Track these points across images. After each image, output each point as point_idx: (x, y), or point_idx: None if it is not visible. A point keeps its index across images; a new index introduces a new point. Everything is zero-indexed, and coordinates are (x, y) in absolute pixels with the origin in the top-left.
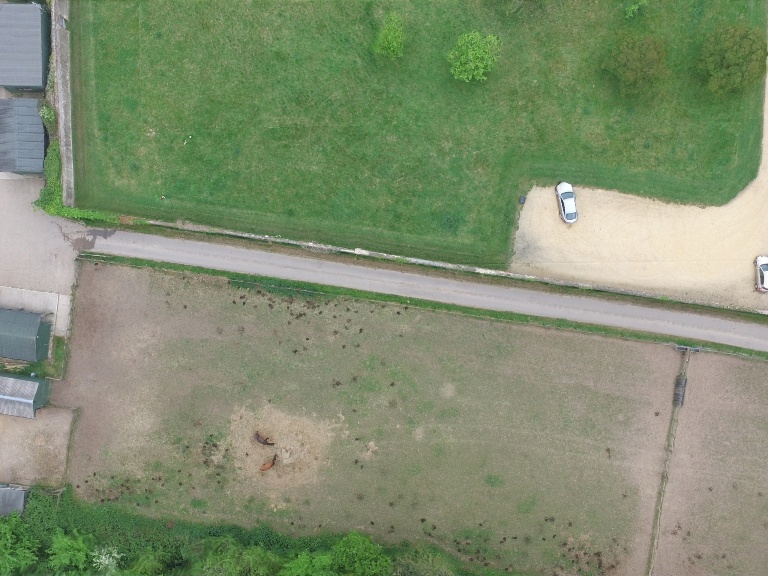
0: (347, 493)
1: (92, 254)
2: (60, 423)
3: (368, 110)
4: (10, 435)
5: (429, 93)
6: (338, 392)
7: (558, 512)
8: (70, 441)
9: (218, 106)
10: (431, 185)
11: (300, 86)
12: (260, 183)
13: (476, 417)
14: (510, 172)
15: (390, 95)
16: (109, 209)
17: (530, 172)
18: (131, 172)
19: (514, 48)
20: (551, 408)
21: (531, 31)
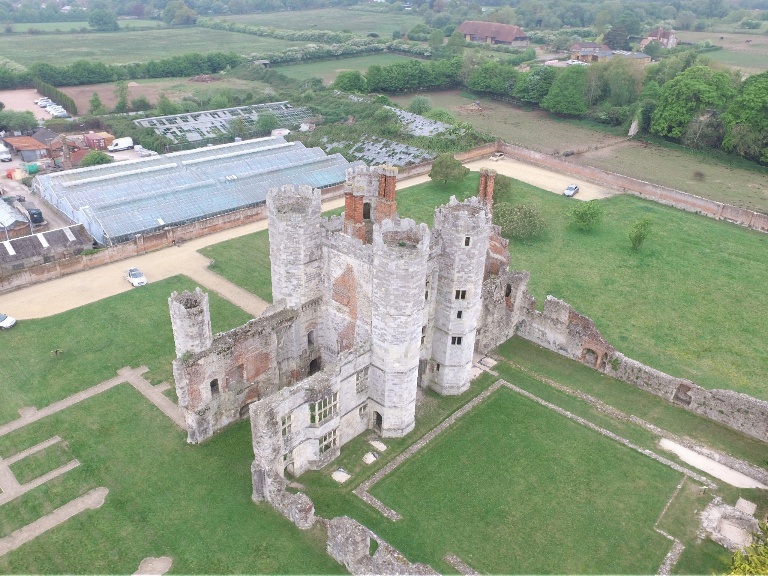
0: None
1: None
2: None
3: None
4: None
5: None
6: None
7: None
8: None
9: None
10: None
11: None
12: None
13: None
14: None
15: None
16: None
17: None
18: None
19: None
20: None
21: None
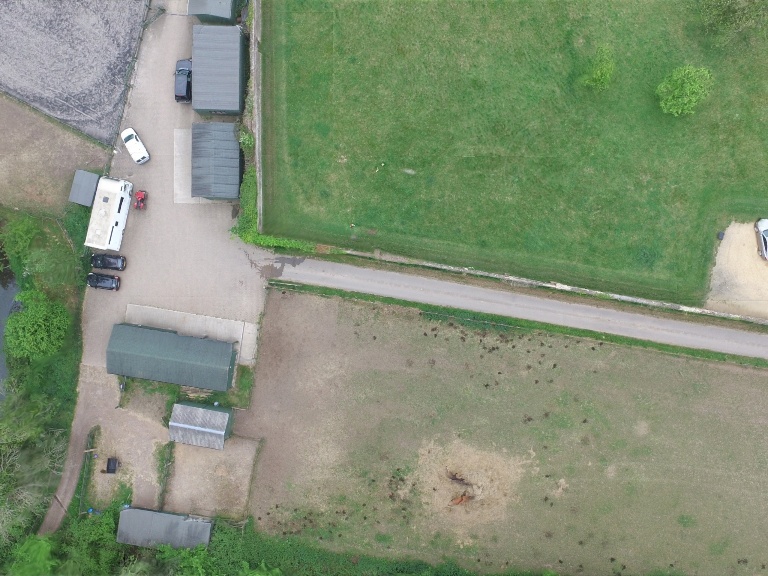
0: (535, 530)
1: (283, 283)
2: (242, 454)
3: (565, 141)
4: (190, 465)
5: (628, 125)
6: (529, 428)
7: (751, 554)
8: (253, 472)
9: (412, 133)
10: (628, 219)
11: (497, 115)
12: (453, 213)
13: (669, 456)
14: (709, 207)
15: (588, 126)
16: (297, 236)
17: (729, 208)
18: (321, 199)
19: (716, 81)
20: (746, 448)
21: (734, 64)
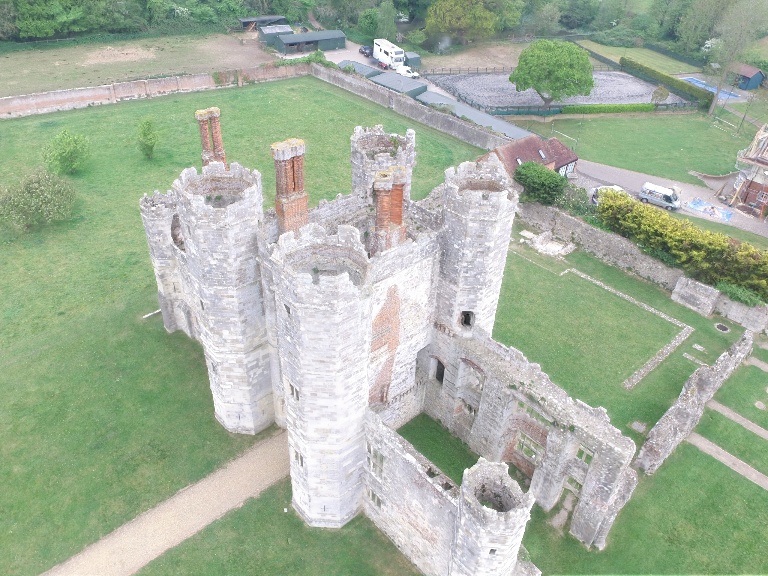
0: None
1: None
2: None
3: None
4: None
5: None
6: None
7: None
8: None
9: None
10: None
11: None
12: None
13: None
14: (6, 149)
15: None
16: (292, 79)
17: None
18: None
19: None
20: None
21: None
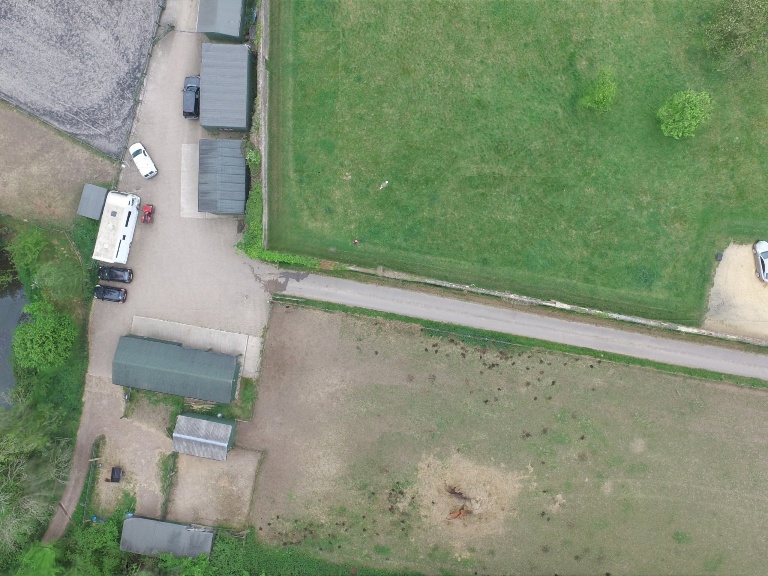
0: (532, 545)
1: None
2: (245, 465)
3: (567, 161)
4: (193, 475)
5: (629, 146)
6: (527, 444)
7: (745, 571)
8: (255, 483)
9: (416, 152)
10: (627, 239)
11: (500, 135)
12: (455, 231)
13: (665, 473)
14: (708, 228)
15: (590, 147)
16: (302, 251)
17: (728, 229)
18: (325, 215)
19: (717, 104)
20: (741, 467)
21: (735, 87)
